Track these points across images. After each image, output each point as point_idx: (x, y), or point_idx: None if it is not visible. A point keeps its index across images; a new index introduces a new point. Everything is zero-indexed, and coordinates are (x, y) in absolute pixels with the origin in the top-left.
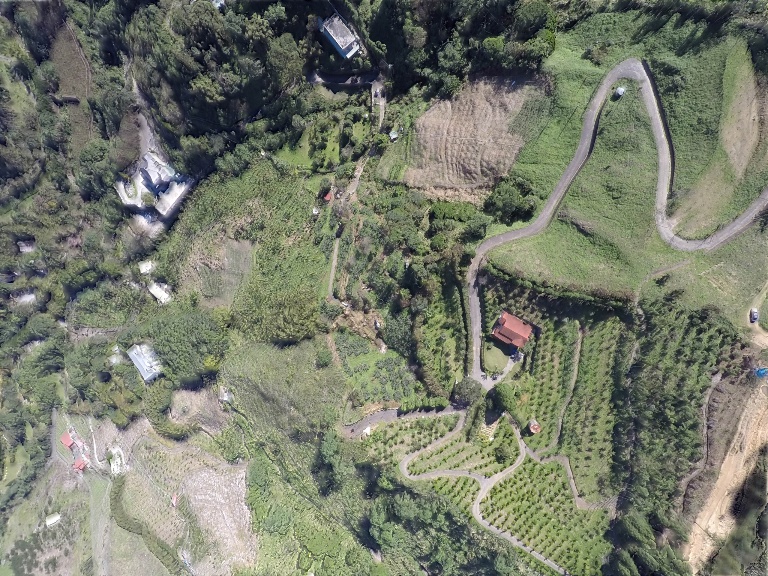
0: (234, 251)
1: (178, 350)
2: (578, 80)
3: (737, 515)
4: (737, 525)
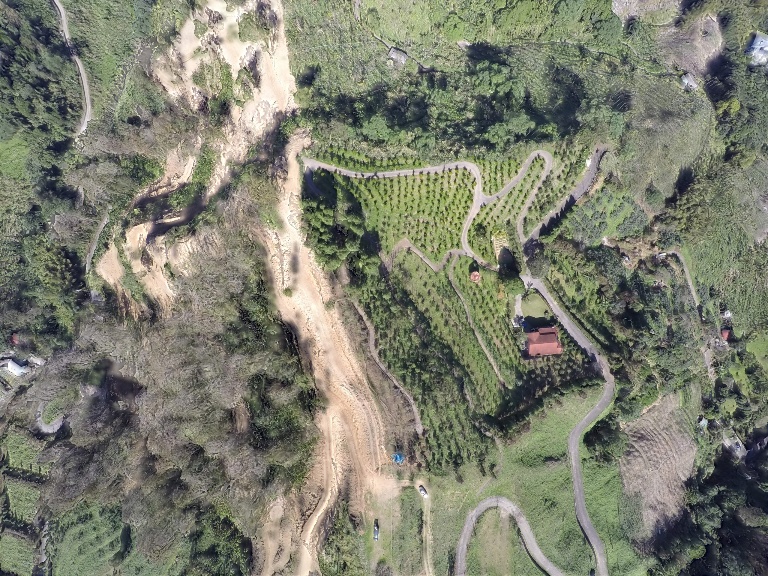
0: (765, 222)
1: (759, 89)
2: (623, 568)
3: (337, 337)
4: (326, 327)
